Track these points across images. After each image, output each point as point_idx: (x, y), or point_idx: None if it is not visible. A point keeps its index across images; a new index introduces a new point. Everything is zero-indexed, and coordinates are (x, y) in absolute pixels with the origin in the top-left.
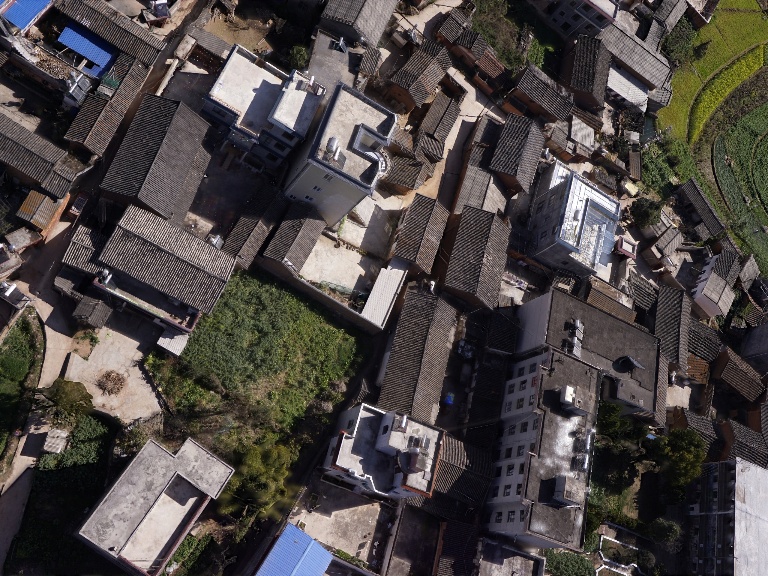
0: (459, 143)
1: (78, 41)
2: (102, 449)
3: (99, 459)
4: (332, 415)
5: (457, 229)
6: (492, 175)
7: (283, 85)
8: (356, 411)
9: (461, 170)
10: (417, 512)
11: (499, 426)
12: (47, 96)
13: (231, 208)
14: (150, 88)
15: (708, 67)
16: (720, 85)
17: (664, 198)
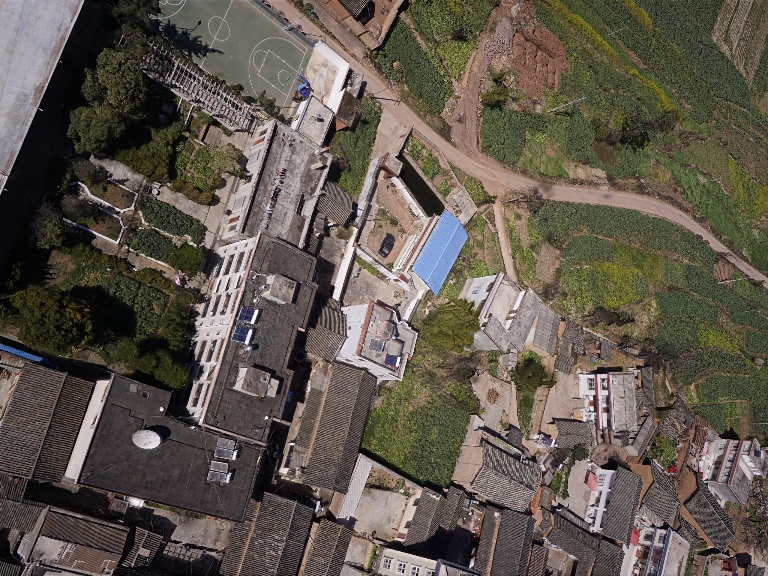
0: None
1: None
2: None
3: None
4: None
5: None
6: None
7: None
8: None
9: None
10: None
11: None
12: None
13: None
14: None
15: None
16: None
17: None
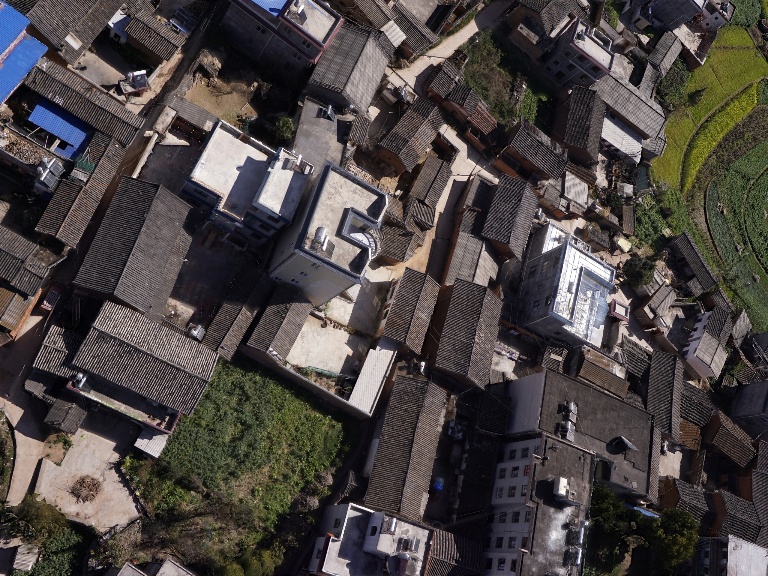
0: (450, 205)
1: (50, 120)
2: (76, 560)
3: (73, 571)
4: (318, 511)
5: (448, 304)
6: (484, 242)
7: (268, 161)
8: (343, 510)
9: (452, 234)
10: None
11: (489, 511)
12: (17, 180)
13: (213, 291)
14: (127, 164)
15: (702, 109)
16: (714, 129)
17: (657, 252)
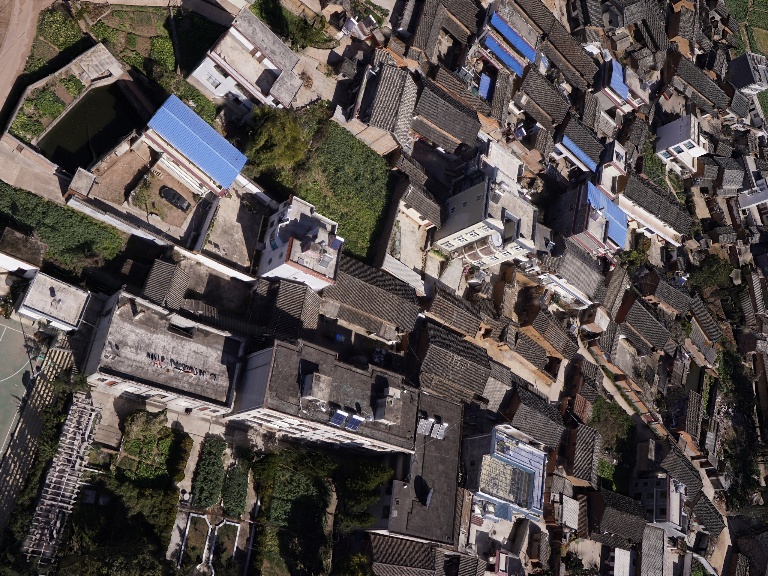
0: None
1: (486, 83)
2: None
3: None
4: None
5: None
6: (512, 388)
7: None
8: None
9: None
10: (245, 303)
11: None
12: None
13: None
14: None
15: None
16: None
17: None
